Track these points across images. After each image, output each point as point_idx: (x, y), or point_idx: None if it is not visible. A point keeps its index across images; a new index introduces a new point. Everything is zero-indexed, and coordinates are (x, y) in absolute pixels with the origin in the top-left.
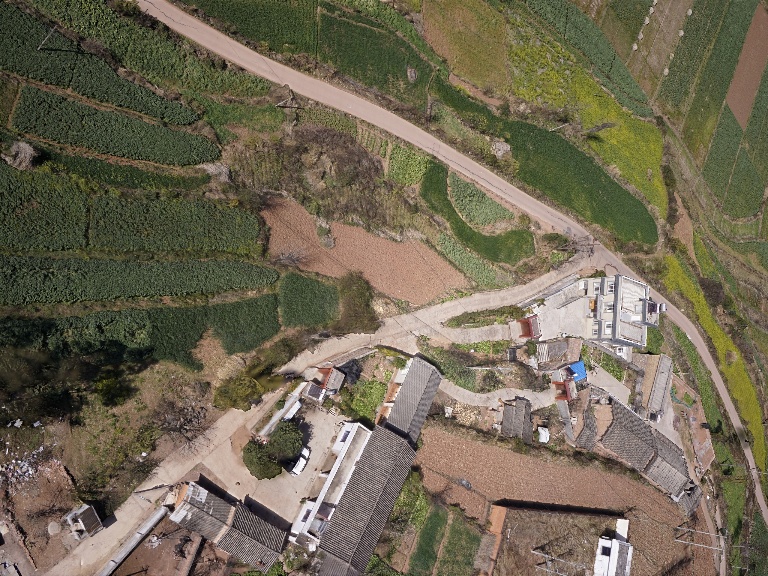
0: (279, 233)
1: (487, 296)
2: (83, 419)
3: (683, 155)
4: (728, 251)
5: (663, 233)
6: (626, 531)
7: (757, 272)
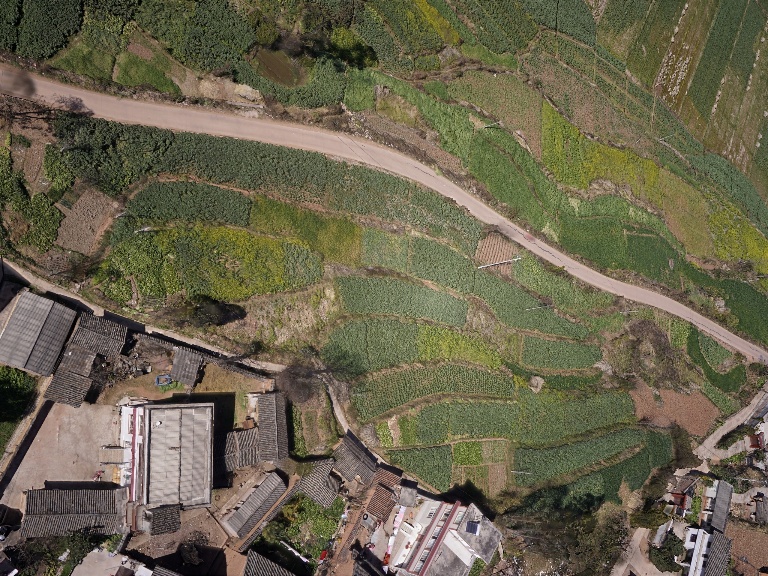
0: (637, 403)
1: (731, 421)
2: (579, 543)
3: None
4: None
5: None
6: None
7: None
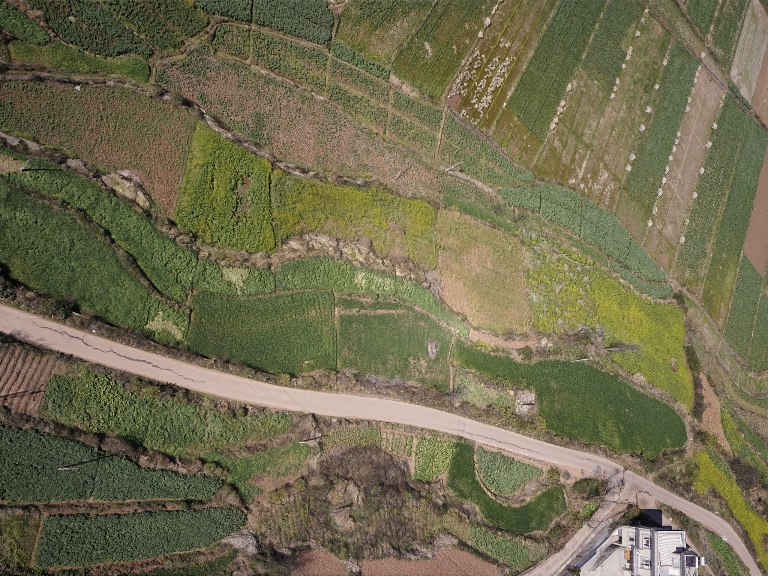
0: None
1: None
2: None
3: (704, 323)
4: (755, 410)
5: (692, 430)
6: None
7: None
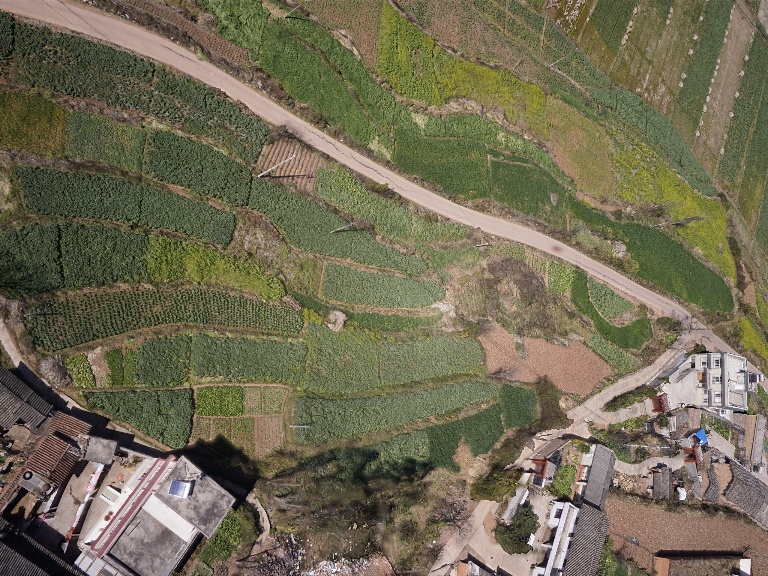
0: (491, 352)
1: (627, 380)
2: (393, 519)
3: (740, 223)
4: None
5: (737, 300)
6: (749, 569)
7: None
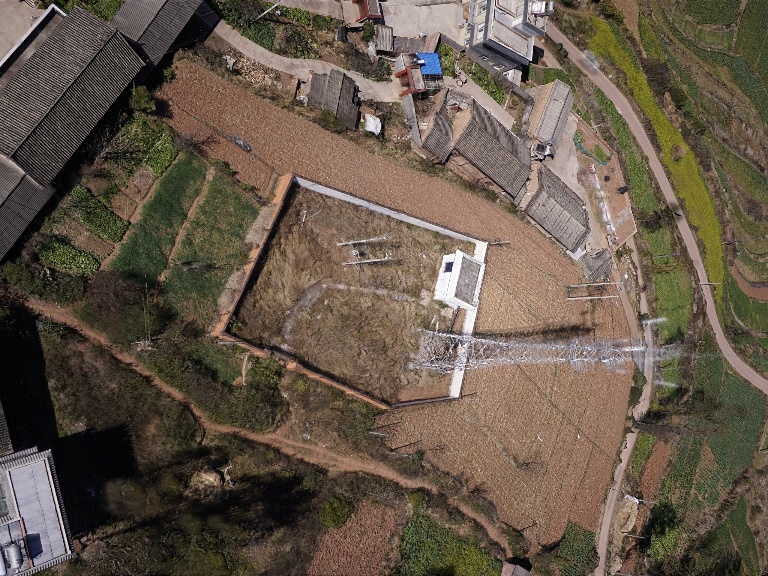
0: None
1: None
2: None
3: None
4: (690, 56)
5: None
6: (483, 255)
7: (728, 87)
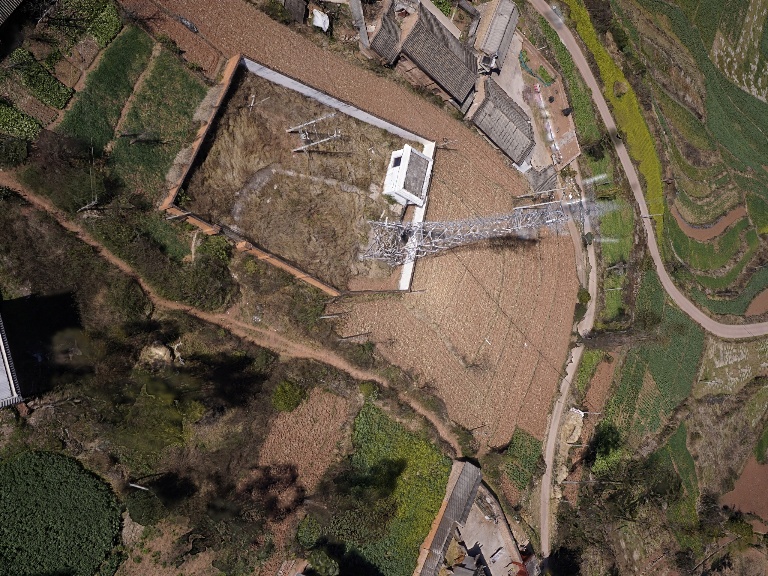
0: None
1: None
2: None
3: None
4: (631, 2)
5: None
6: (431, 154)
7: (667, 36)
